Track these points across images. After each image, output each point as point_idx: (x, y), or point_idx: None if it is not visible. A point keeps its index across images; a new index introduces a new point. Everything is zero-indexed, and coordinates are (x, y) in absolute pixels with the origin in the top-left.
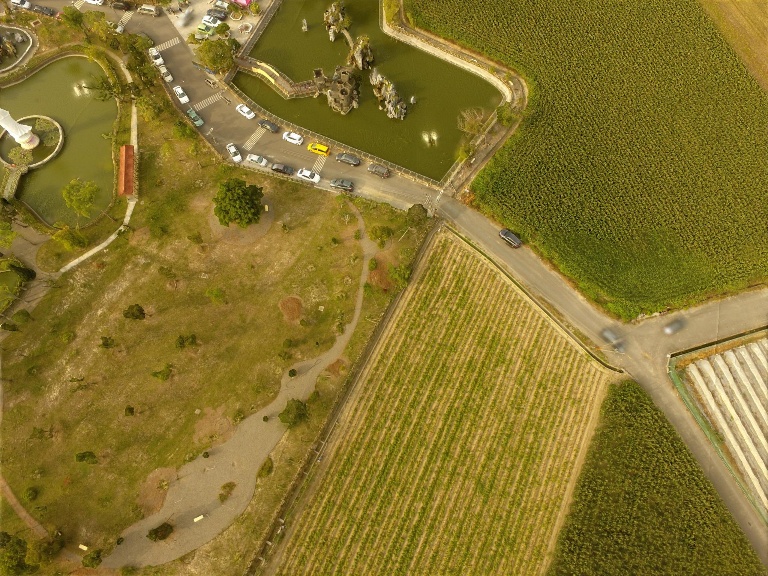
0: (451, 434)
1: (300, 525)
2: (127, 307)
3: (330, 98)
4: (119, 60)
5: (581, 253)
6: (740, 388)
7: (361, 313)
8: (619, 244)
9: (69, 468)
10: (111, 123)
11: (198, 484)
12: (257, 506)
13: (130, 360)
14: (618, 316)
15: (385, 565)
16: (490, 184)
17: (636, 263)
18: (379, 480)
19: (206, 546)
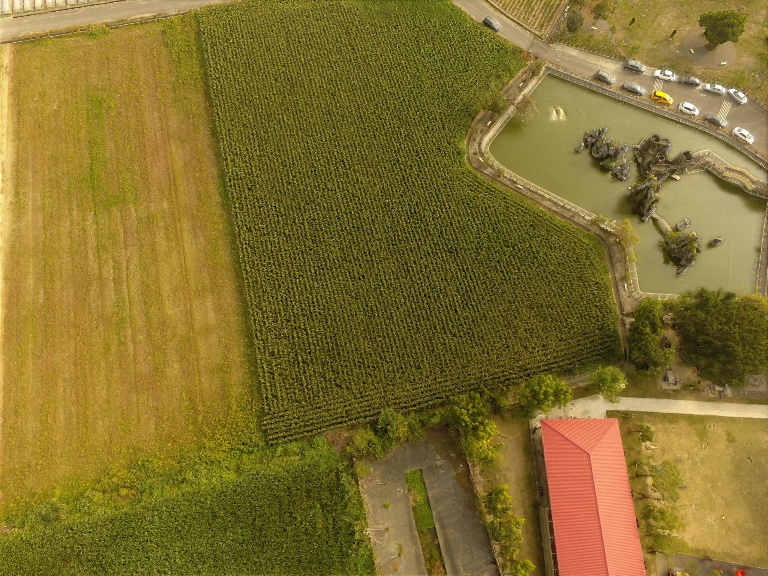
0: None
1: None
2: None
3: None
4: None
5: (439, 8)
6: None
7: None
8: None
9: None
10: None
11: None
12: None
13: None
14: None
15: None
16: None
17: (398, 1)
18: None
19: None
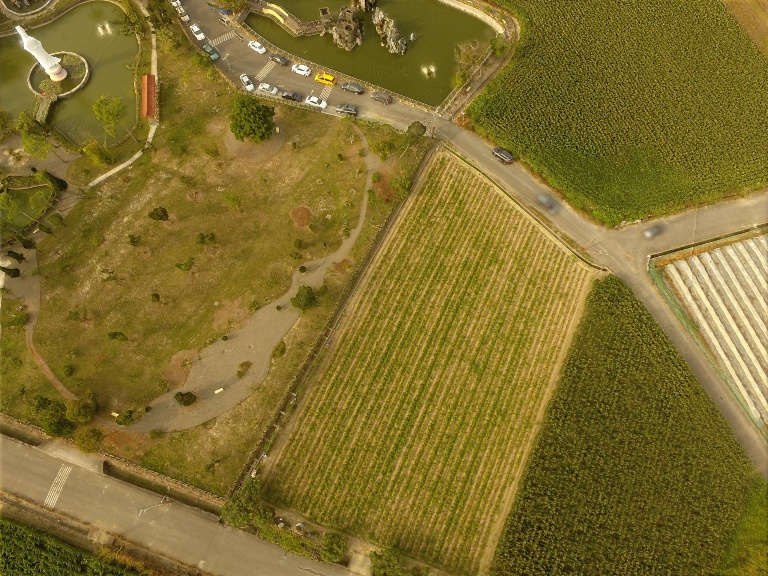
0: (448, 323)
1: (311, 398)
2: None
3: (335, 35)
4: (139, 3)
5: (568, 167)
6: (715, 285)
7: (365, 220)
8: (604, 159)
9: (101, 350)
10: (133, 59)
11: (218, 363)
12: (272, 382)
13: (154, 260)
14: (602, 222)
15: (388, 432)
16: (484, 108)
17: (619, 176)
18: (382, 361)
19: (226, 414)
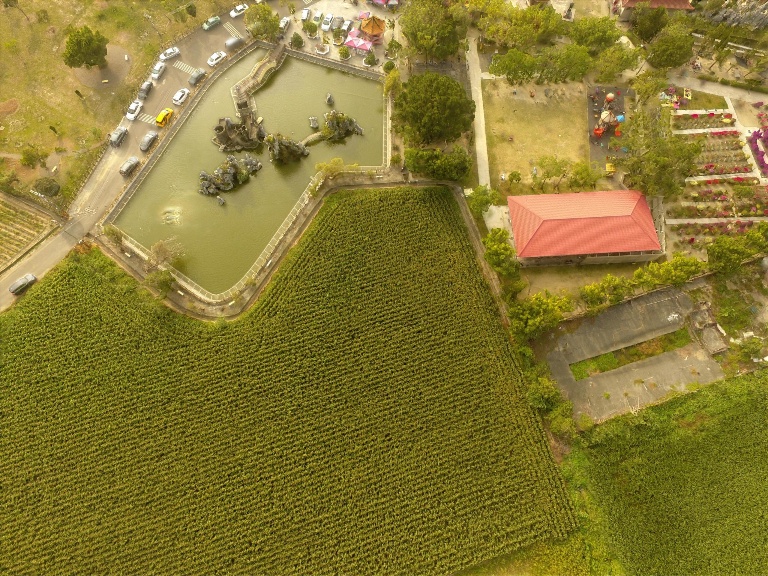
0: None
1: None
2: (40, 6)
3: None
4: None
5: None
6: None
7: None
8: None
9: None
10: None
11: None
12: None
13: None
14: None
15: None
16: None
17: None
18: None
19: None
